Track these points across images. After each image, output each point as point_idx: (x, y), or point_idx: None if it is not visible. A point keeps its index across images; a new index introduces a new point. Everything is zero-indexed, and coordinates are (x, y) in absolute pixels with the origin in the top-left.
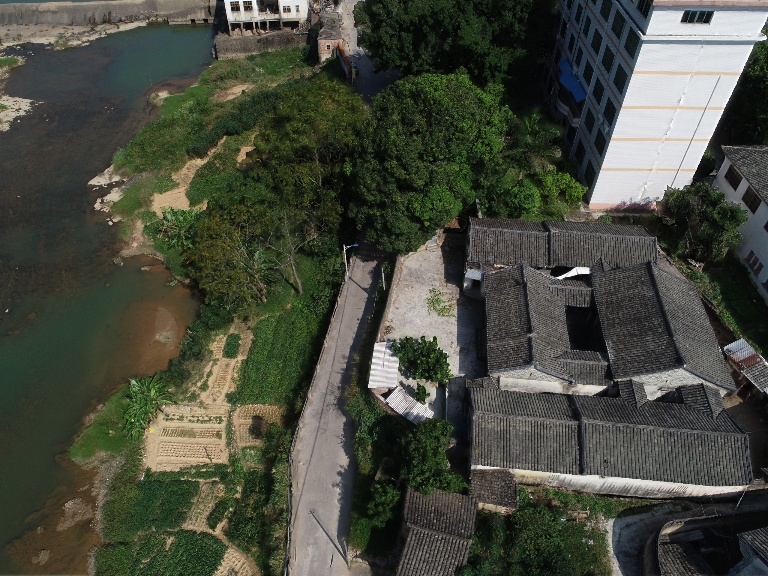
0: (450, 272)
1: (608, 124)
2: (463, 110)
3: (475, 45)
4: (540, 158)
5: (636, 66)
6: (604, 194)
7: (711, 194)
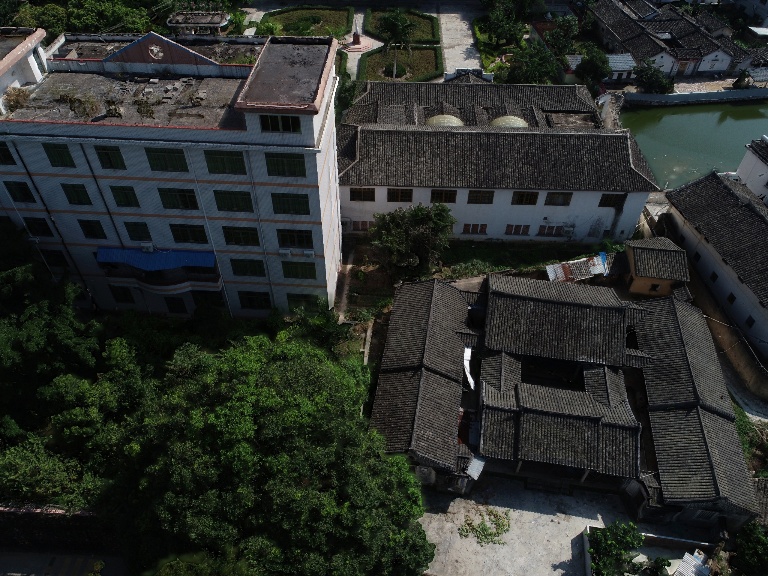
0: (426, 505)
1: (304, 249)
2: None
3: (29, 343)
4: None
5: (318, 180)
6: (331, 302)
7: (409, 215)
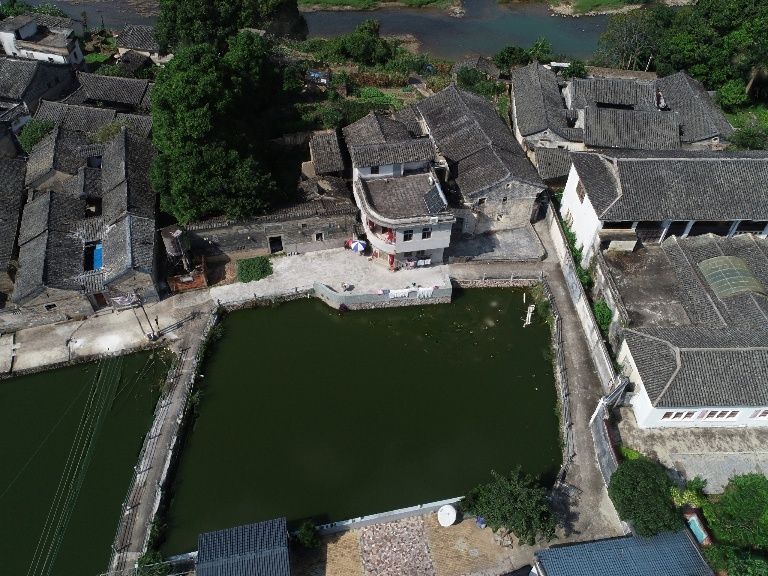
0: None
1: None
2: (744, 0)
3: None
4: (757, 67)
5: None
6: None
7: None
